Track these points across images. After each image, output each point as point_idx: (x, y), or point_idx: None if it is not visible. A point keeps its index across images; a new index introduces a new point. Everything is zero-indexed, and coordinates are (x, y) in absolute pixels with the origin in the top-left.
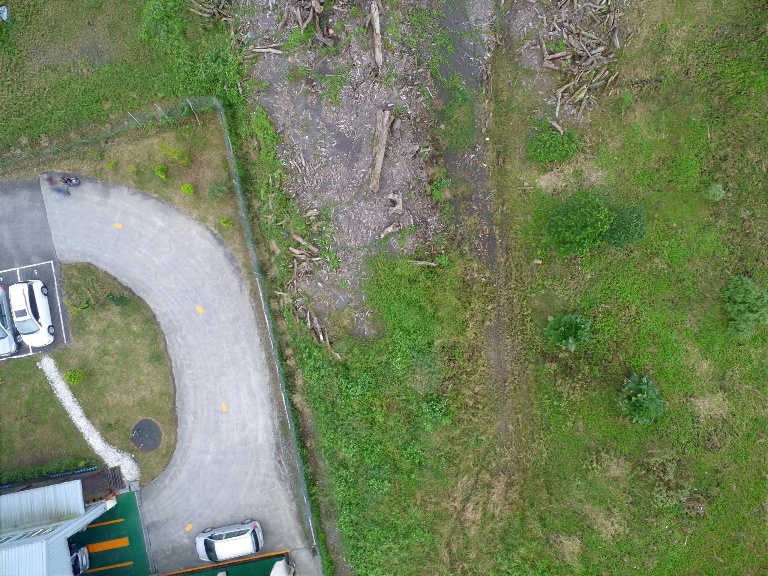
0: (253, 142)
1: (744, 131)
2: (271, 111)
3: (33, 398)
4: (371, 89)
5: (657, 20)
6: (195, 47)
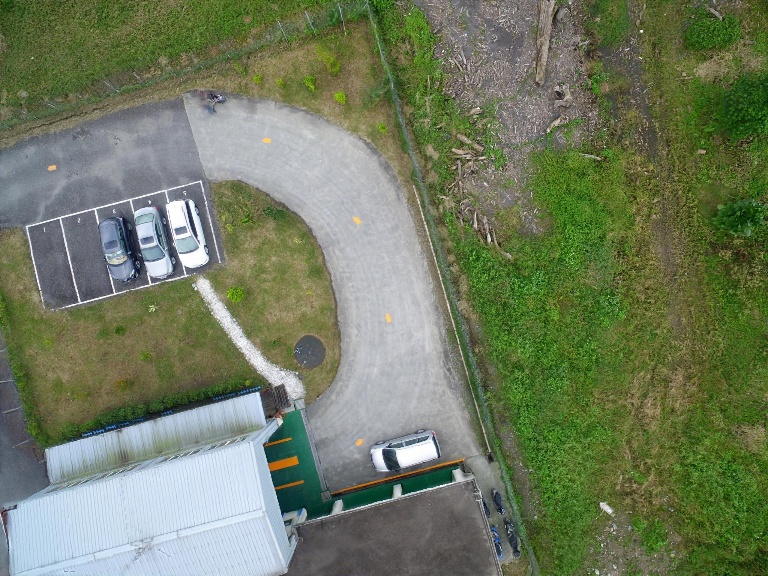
0: (405, 46)
1: None
2: (427, 11)
3: (190, 321)
4: None
5: None
6: None
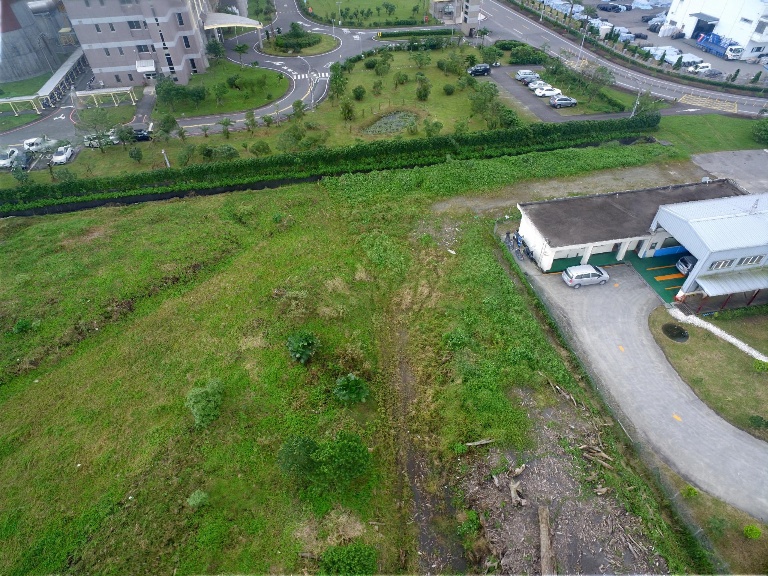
0: None
1: (138, 573)
2: None
3: None
4: None
5: None
6: None
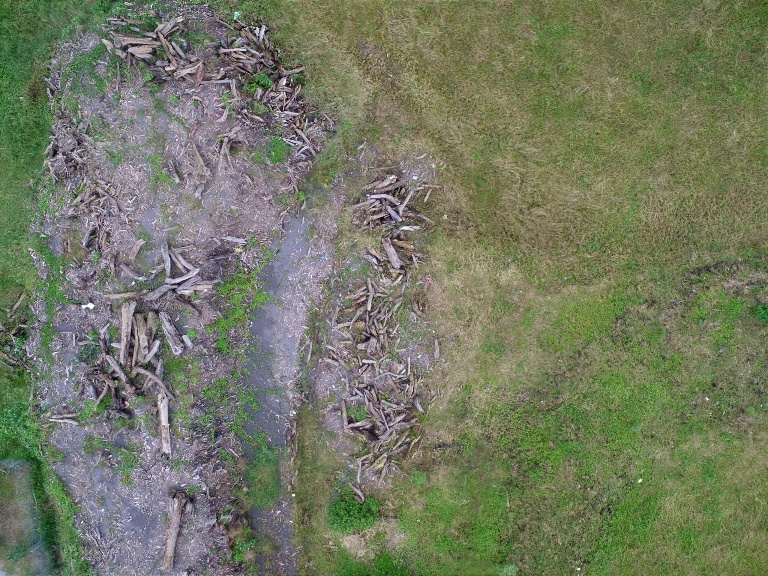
0: None
1: (541, 504)
2: (68, 481)
3: None
4: (163, 471)
5: (462, 380)
6: (0, 398)
